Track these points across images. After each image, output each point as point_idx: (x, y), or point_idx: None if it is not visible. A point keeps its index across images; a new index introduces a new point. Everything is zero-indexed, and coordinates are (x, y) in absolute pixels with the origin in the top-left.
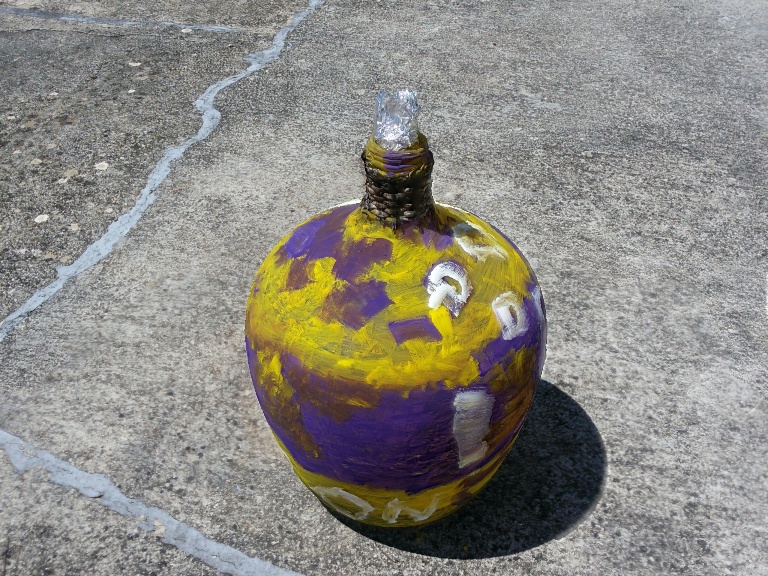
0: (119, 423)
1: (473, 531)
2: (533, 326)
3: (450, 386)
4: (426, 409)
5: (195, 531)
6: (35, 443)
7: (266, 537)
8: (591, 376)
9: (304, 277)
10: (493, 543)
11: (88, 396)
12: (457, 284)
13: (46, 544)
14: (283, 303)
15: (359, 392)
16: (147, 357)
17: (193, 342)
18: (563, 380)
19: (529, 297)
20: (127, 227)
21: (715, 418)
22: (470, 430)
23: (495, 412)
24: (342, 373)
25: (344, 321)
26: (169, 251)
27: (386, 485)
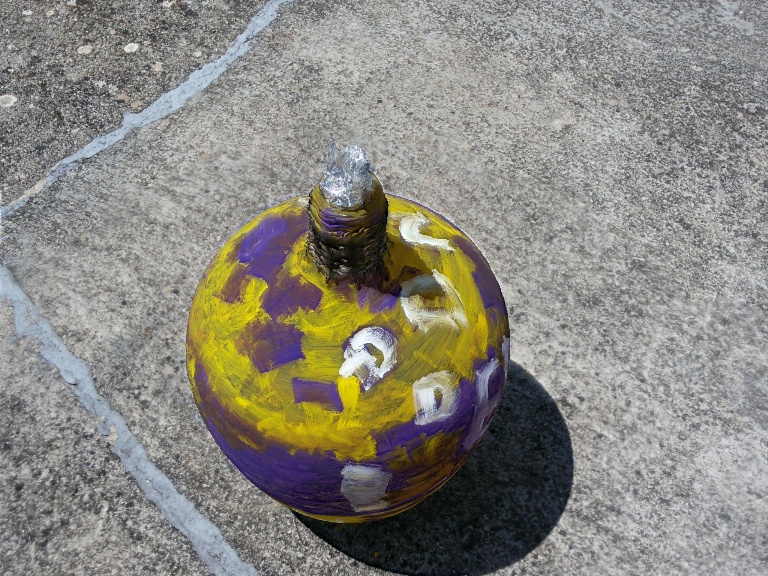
0: (119, 310)
1: (392, 539)
2: (462, 410)
3: (339, 458)
4: (311, 469)
5: (142, 449)
6: (41, 309)
7: (200, 477)
8: (599, 402)
9: (236, 290)
10: (405, 558)
11: (103, 271)
12: (380, 354)
13: (15, 418)
14: (212, 309)
15: (249, 433)
16: (171, 243)
17: (219, 238)
18: (566, 397)
19: (470, 377)
20: (208, 80)
21: (710, 496)
22: (361, 494)
23: (393, 484)
24: (237, 409)
25: (252, 358)
26: (238, 121)
27: (283, 501)
